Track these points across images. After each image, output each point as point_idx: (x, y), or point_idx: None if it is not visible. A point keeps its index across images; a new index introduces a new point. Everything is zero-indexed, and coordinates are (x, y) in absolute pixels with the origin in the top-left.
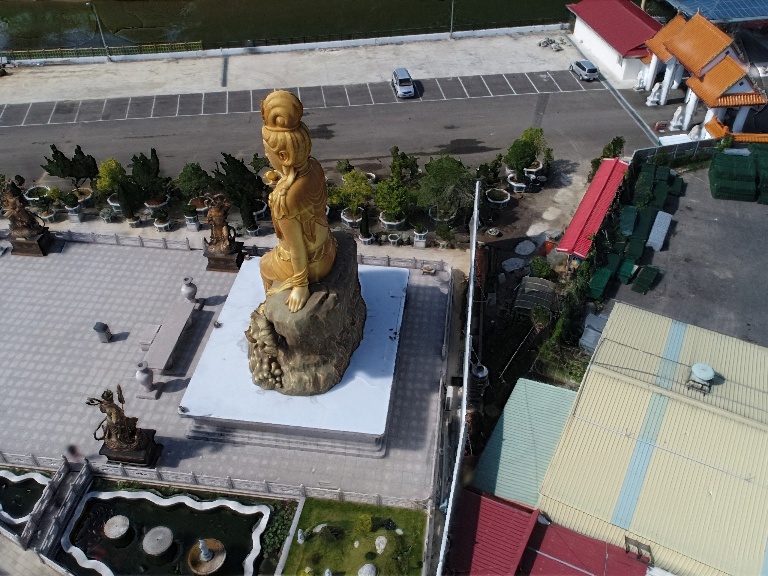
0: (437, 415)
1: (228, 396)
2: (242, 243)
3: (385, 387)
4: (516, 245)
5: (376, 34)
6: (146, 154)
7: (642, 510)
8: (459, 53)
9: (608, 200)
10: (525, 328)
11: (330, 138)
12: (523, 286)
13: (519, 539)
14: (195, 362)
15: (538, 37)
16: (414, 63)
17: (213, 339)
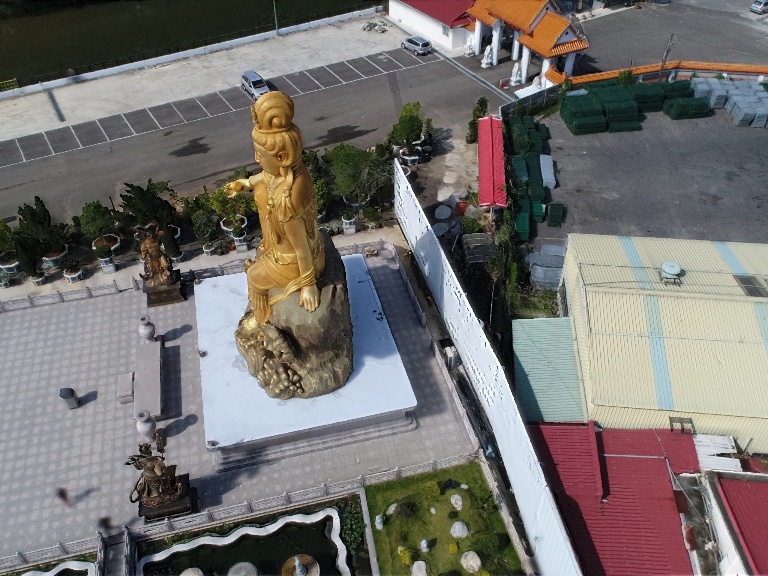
0: (448, 376)
1: (251, 417)
2: (179, 270)
3: (397, 363)
4: (434, 212)
5: (204, 42)
6: (11, 207)
7: (677, 391)
8: (293, 48)
9: (500, 153)
10: (482, 280)
11: (207, 151)
12: (467, 244)
13: (589, 449)
14: (185, 399)
15: (359, 22)
16: (254, 65)
17: (205, 368)
